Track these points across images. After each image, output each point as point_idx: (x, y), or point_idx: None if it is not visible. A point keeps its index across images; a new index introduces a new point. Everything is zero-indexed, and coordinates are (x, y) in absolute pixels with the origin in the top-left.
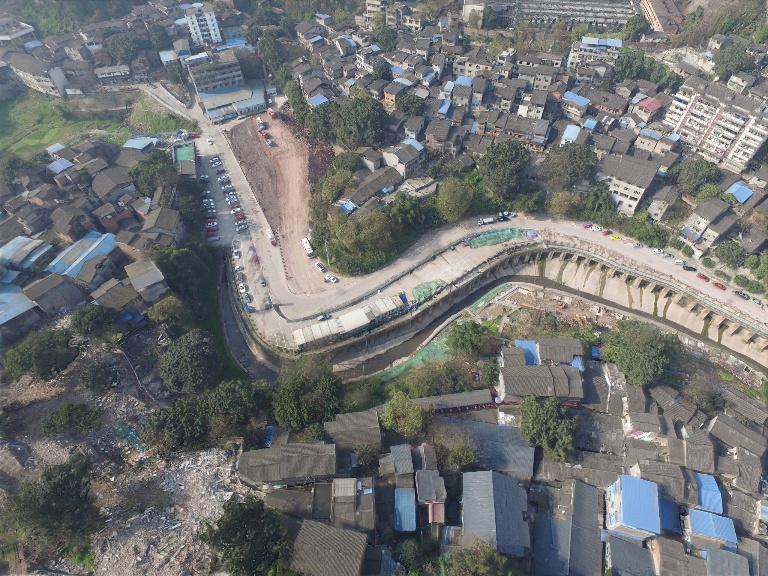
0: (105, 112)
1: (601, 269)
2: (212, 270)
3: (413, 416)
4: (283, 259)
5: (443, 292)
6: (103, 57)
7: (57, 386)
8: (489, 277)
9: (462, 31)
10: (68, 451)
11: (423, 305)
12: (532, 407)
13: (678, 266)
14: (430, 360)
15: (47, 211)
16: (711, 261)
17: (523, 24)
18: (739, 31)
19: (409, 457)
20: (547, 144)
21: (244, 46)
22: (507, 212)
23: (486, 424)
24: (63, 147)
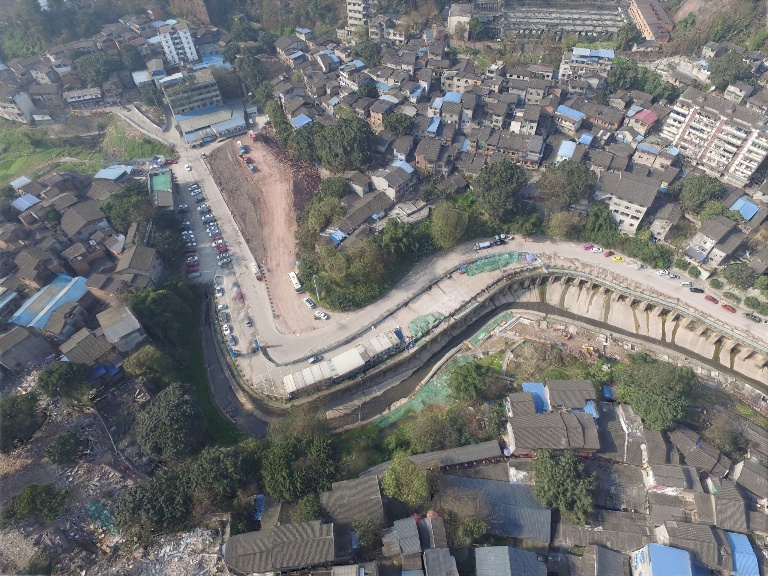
0: (76, 138)
1: (604, 293)
2: (194, 309)
3: (418, 484)
4: (269, 295)
5: (441, 325)
6: (72, 80)
7: (22, 457)
8: (488, 305)
9: (448, 43)
10: (32, 542)
11: (420, 341)
12: (546, 465)
13: (685, 288)
14: (430, 402)
15: (11, 254)
16: (719, 282)
17: (511, 35)
18: (732, 38)
19: (415, 534)
20: (542, 161)
21: (222, 64)
22: (504, 235)
23: (496, 482)
24: (29, 181)
